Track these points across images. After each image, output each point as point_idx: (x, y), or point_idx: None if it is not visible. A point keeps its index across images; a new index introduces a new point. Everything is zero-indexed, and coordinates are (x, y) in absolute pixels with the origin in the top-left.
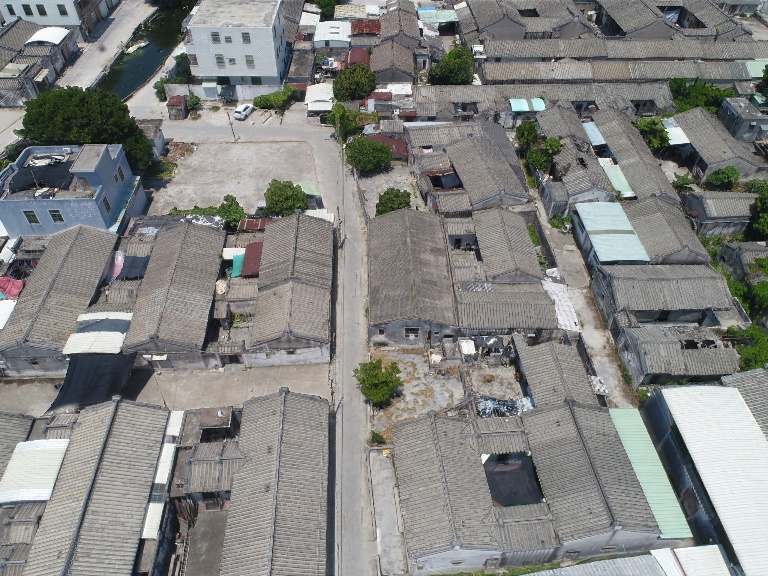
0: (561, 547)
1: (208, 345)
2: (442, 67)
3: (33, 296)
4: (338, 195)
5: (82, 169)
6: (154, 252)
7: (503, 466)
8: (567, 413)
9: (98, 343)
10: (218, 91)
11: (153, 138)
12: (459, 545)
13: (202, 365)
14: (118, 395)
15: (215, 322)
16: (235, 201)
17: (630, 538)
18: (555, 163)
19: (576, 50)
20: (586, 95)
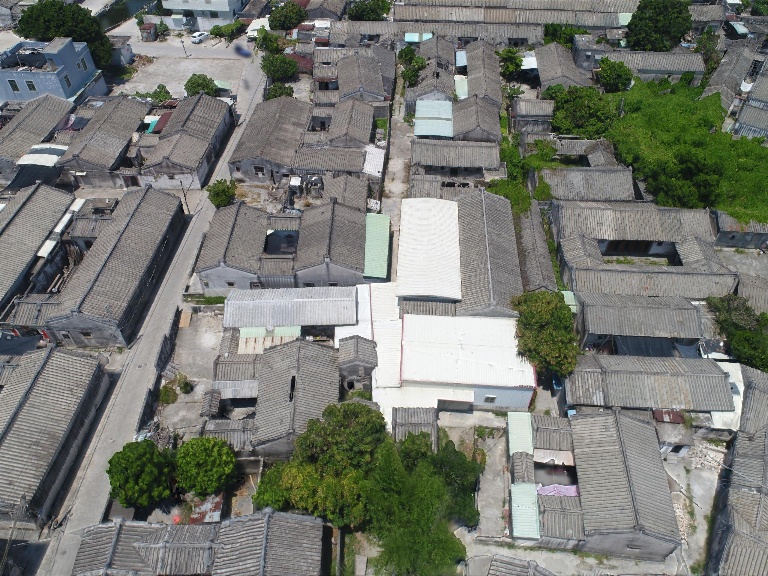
0: (298, 278)
1: (117, 170)
2: (356, 6)
3: (5, 132)
4: (250, 94)
5: (49, 51)
6: (95, 114)
7: (293, 249)
8: (330, 207)
9: (40, 160)
10: (184, 22)
11: (120, 48)
12: (222, 261)
13: (112, 184)
14: (40, 180)
15: (128, 161)
16: (165, 89)
17: (343, 275)
18: None
19: (481, 1)
20: (471, 33)
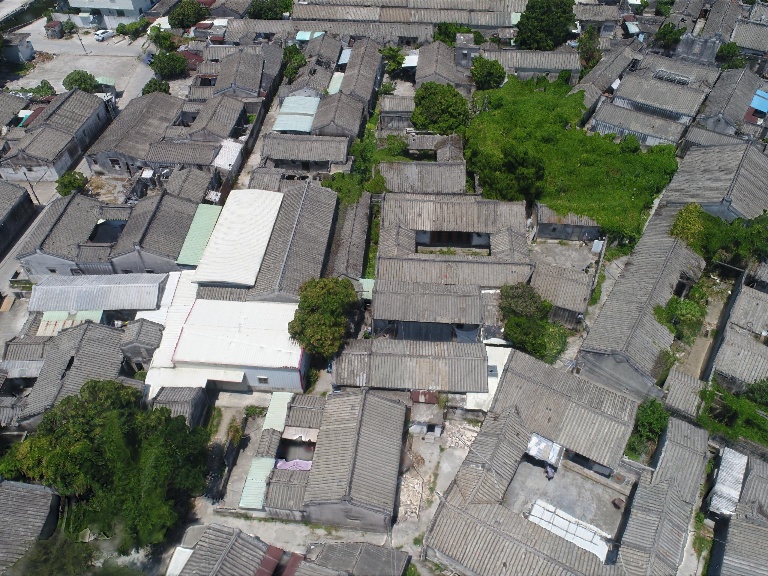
0: (115, 265)
1: None
2: (254, 5)
3: None
4: (137, 91)
5: None
6: None
7: None
8: None
9: None
10: (91, 20)
11: (16, 45)
12: (37, 248)
13: None
14: None
15: None
16: (48, 84)
17: (157, 262)
18: (298, 73)
19: (382, 0)
20: (363, 31)
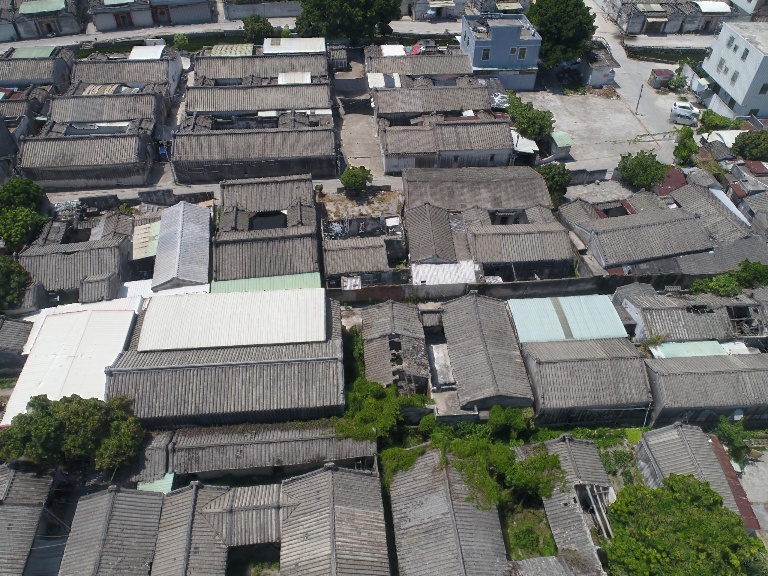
0: None
1: None
2: None
3: None
4: None
5: None
6: None
7: None
8: None
9: (375, 80)
10: None
11: (592, 67)
12: None
13: None
14: None
15: None
16: (528, 108)
17: None
18: None
19: None
20: None
